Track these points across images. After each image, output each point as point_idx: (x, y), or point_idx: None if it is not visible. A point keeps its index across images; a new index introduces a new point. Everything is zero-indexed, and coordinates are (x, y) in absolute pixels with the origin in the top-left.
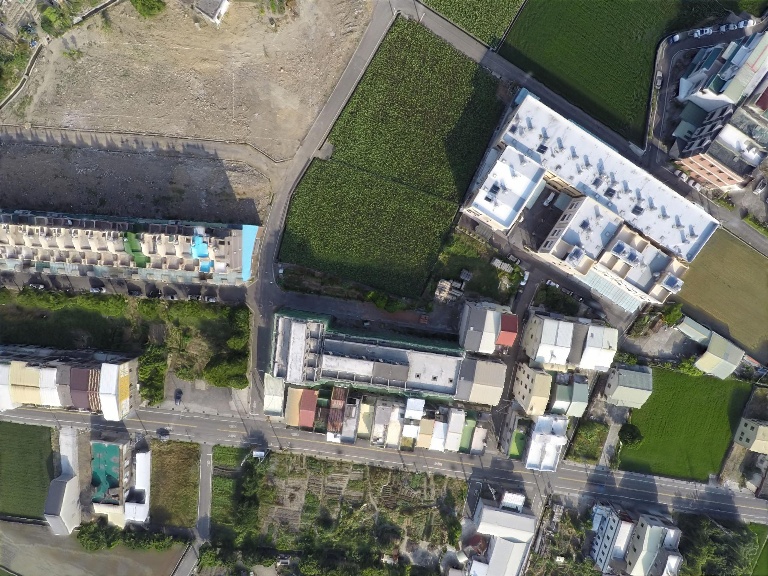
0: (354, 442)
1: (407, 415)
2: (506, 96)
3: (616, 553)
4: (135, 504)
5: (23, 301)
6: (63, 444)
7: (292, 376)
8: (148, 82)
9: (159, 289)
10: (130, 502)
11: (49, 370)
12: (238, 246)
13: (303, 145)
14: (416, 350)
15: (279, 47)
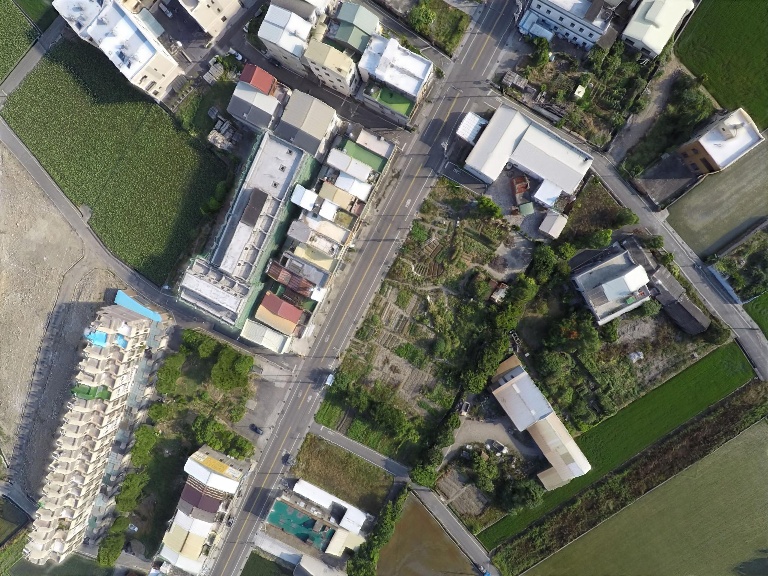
0: (327, 275)
1: (307, 208)
2: (74, 33)
3: (581, 11)
4: (344, 517)
5: (123, 507)
6: (269, 549)
7: (232, 305)
8: (4, 333)
9: (157, 399)
10: (341, 521)
11: (177, 516)
12: (124, 311)
13: (75, 229)
14: (246, 177)
15: (1, 220)
